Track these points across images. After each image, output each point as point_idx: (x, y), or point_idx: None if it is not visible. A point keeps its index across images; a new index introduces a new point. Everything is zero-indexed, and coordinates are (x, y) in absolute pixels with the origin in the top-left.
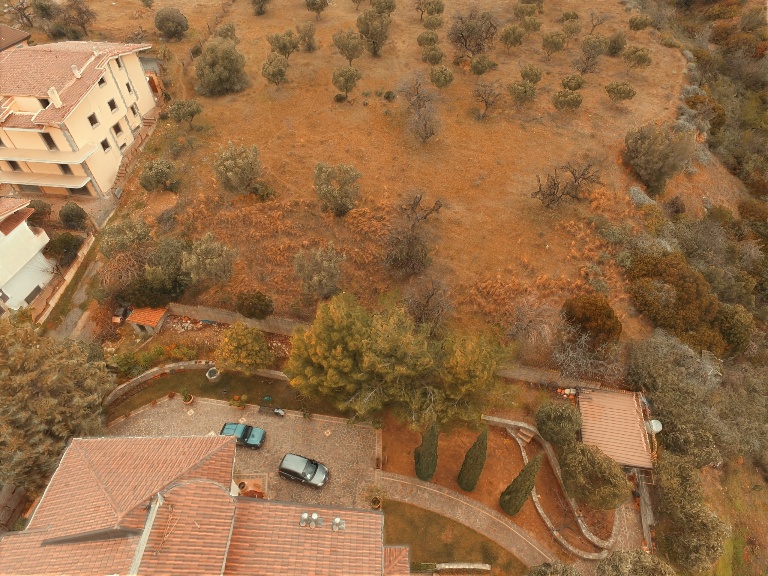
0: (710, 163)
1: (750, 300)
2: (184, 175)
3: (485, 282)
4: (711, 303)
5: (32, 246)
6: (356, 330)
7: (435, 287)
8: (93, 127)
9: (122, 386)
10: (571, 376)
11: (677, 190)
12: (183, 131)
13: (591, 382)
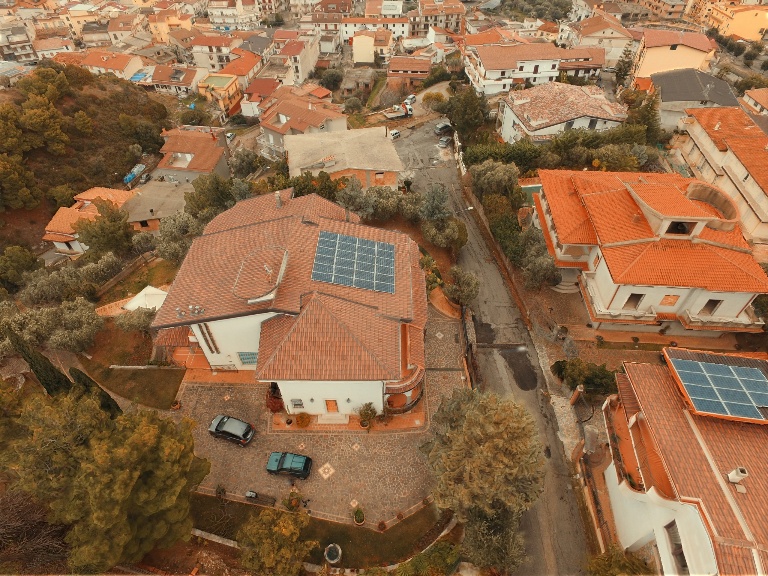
0: None
1: None
2: None
3: None
4: None
5: None
6: (90, 452)
7: None
8: None
9: (443, 533)
10: None
11: None
12: None
13: None
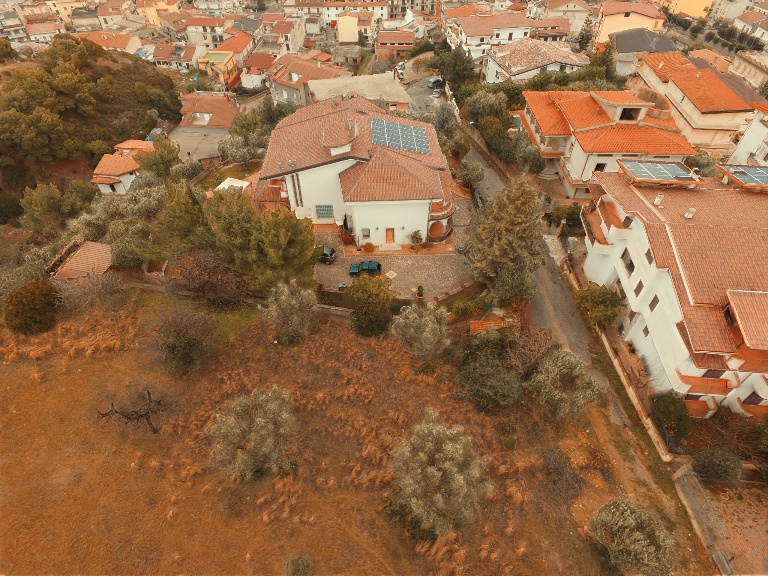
0: None
1: None
2: None
3: (109, 351)
4: None
5: (669, 361)
6: None
7: None
8: None
9: None
10: None
11: None
12: None
13: None
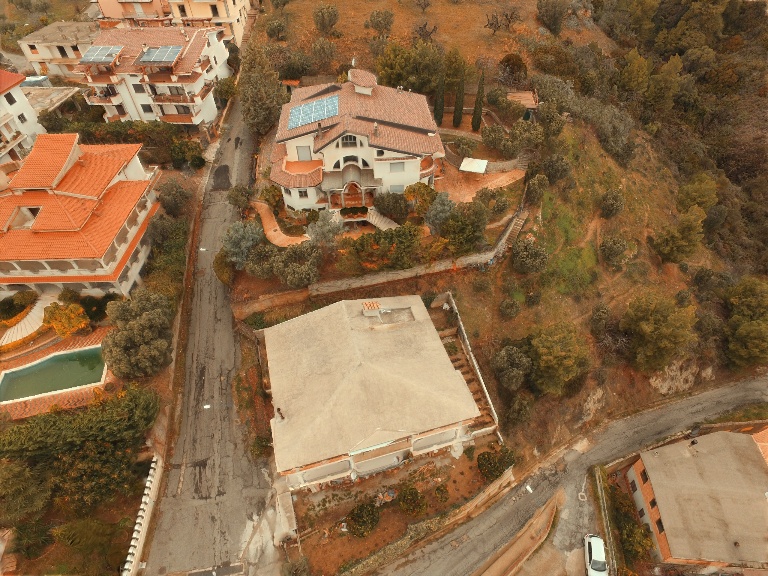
0: (593, 29)
1: (603, 81)
2: (287, 33)
3: None
4: (575, 68)
5: (225, 54)
6: None
7: (438, 48)
8: (234, 6)
9: None
10: (503, 84)
11: (570, 38)
12: (277, 16)
13: (512, 88)
